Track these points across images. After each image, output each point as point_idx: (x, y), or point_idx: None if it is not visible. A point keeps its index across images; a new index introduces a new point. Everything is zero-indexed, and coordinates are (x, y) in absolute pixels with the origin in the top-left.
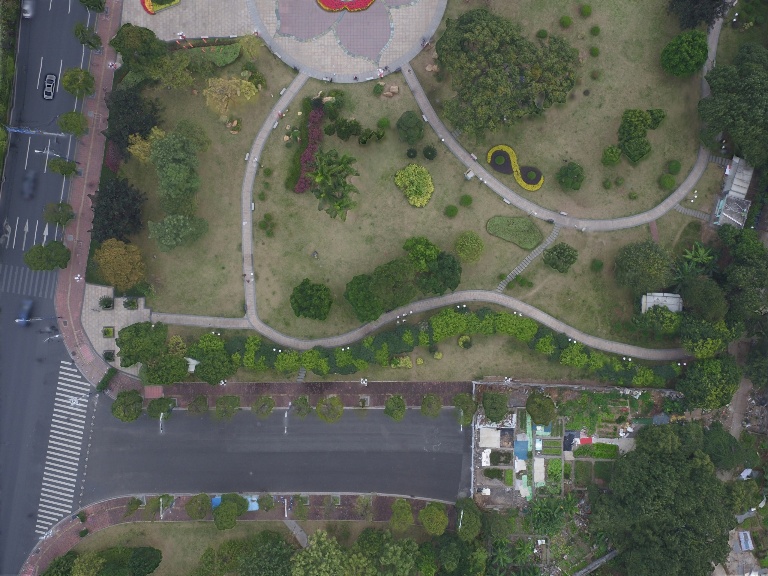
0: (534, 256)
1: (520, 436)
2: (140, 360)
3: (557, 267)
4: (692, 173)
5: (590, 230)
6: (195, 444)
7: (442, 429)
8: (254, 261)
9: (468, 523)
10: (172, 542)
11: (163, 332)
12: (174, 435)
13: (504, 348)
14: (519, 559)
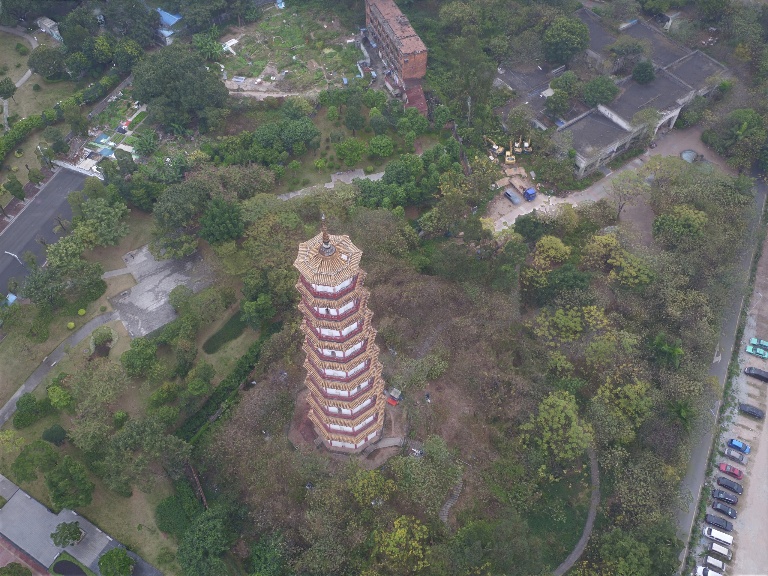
0: (7, 112)
1: (98, 150)
2: None
3: (7, 88)
4: (31, 43)
5: (19, 87)
6: None
7: (62, 185)
8: None
9: (103, 164)
10: None
11: None
12: None
13: (42, 139)
14: (163, 168)
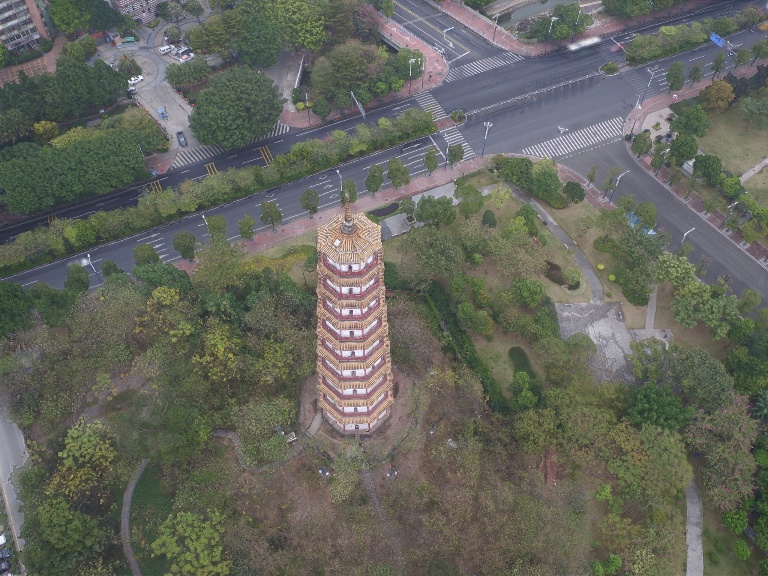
0: None
1: None
2: (681, 130)
3: None
4: None
5: None
6: (644, 194)
7: None
8: (766, 167)
9: None
10: (582, 212)
11: (705, 131)
12: (638, 182)
13: None
14: None
